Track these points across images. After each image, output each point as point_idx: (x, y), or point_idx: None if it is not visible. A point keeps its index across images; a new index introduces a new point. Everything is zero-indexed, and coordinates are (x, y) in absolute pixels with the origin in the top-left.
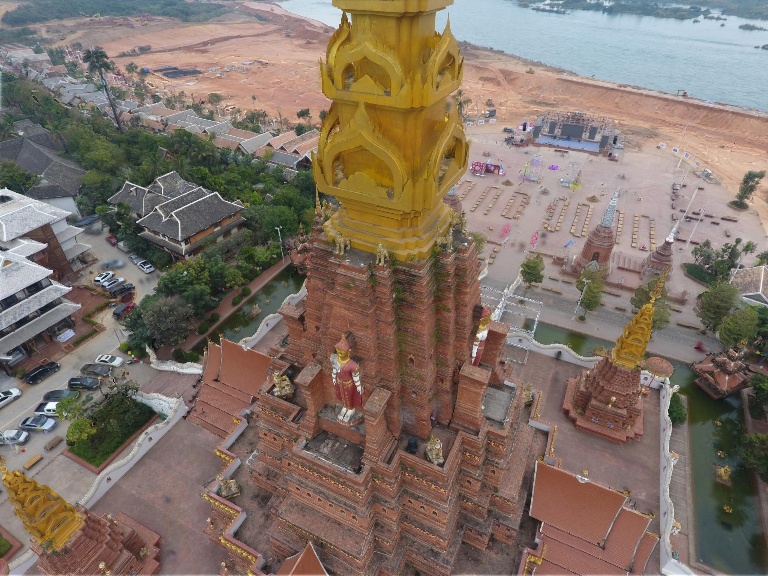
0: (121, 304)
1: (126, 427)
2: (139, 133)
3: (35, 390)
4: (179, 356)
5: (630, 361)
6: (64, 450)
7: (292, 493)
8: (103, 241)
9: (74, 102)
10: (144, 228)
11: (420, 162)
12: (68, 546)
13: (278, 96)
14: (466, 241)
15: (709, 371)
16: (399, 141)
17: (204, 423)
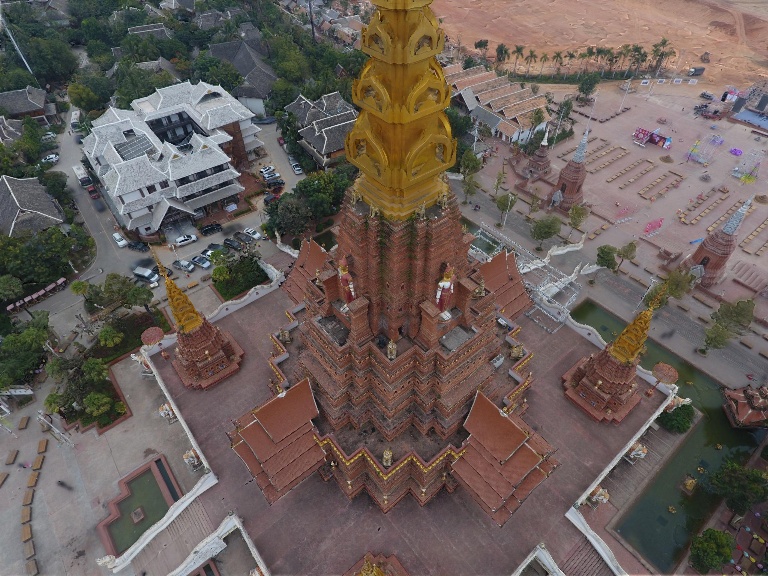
0: (272, 194)
1: (248, 282)
2: (327, 48)
3: (205, 240)
4: (296, 244)
5: (623, 356)
6: (211, 284)
7: (310, 348)
8: (275, 140)
9: (291, 5)
10: (303, 137)
11: (405, 156)
12: (191, 333)
13: (471, 18)
14: (439, 215)
15: (735, 399)
16: (390, 140)
17: (290, 294)
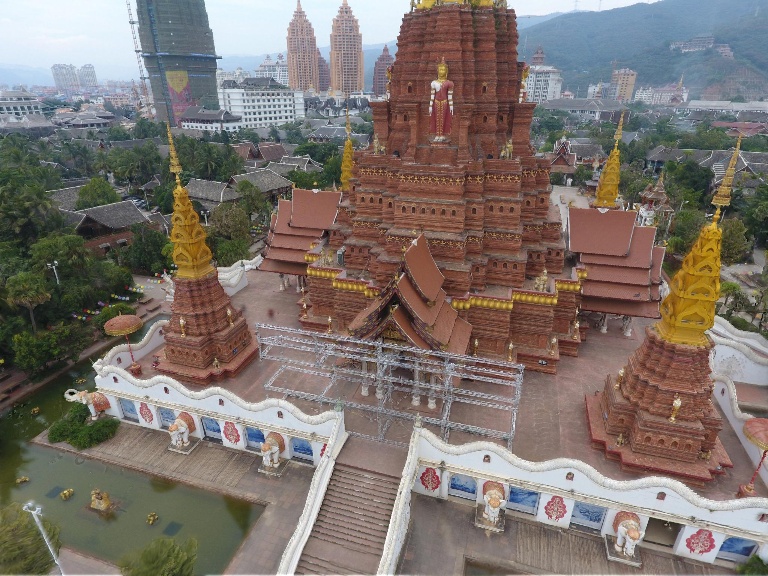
0: None
1: None
2: None
3: None
4: None
5: None
6: None
7: None
8: None
9: None
10: None
11: None
12: None
13: None
14: None
15: None
16: None
17: None
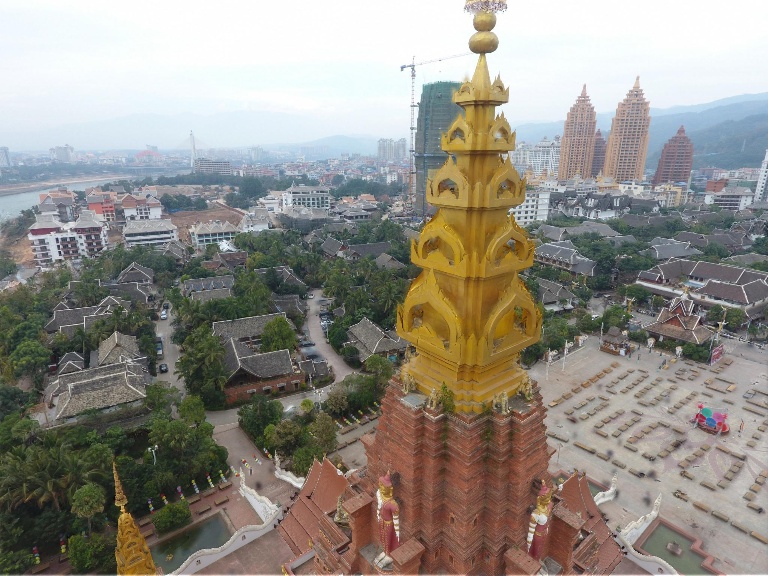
0: None
1: None
2: None
3: None
4: None
5: None
6: None
7: None
8: None
9: None
10: None
11: None
12: None
13: None
14: None
15: None
16: None
17: None
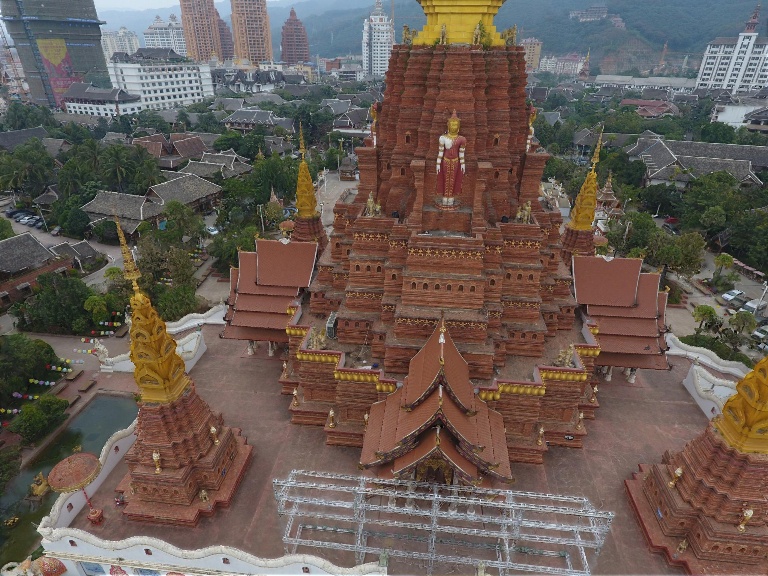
0: None
1: None
2: None
3: None
4: None
5: None
6: None
7: None
8: None
9: None
10: None
11: None
12: None
13: None
14: None
15: None
16: None
17: None
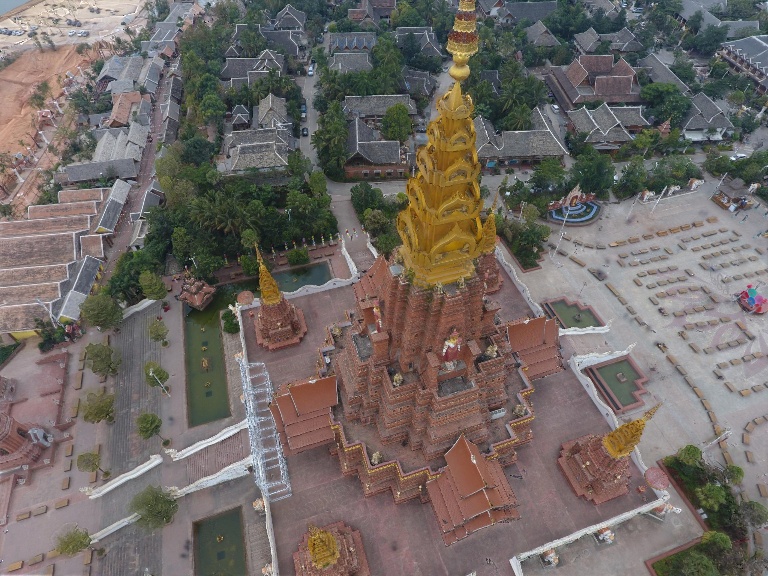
0: None
1: None
2: None
3: None
4: None
5: None
6: None
7: None
8: None
9: None
10: None
11: None
12: None
13: None
14: None
15: None
16: None
17: None
